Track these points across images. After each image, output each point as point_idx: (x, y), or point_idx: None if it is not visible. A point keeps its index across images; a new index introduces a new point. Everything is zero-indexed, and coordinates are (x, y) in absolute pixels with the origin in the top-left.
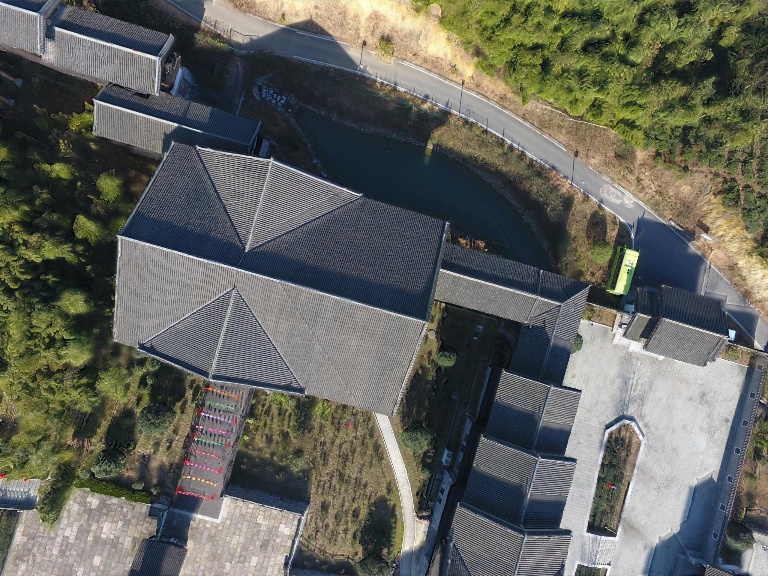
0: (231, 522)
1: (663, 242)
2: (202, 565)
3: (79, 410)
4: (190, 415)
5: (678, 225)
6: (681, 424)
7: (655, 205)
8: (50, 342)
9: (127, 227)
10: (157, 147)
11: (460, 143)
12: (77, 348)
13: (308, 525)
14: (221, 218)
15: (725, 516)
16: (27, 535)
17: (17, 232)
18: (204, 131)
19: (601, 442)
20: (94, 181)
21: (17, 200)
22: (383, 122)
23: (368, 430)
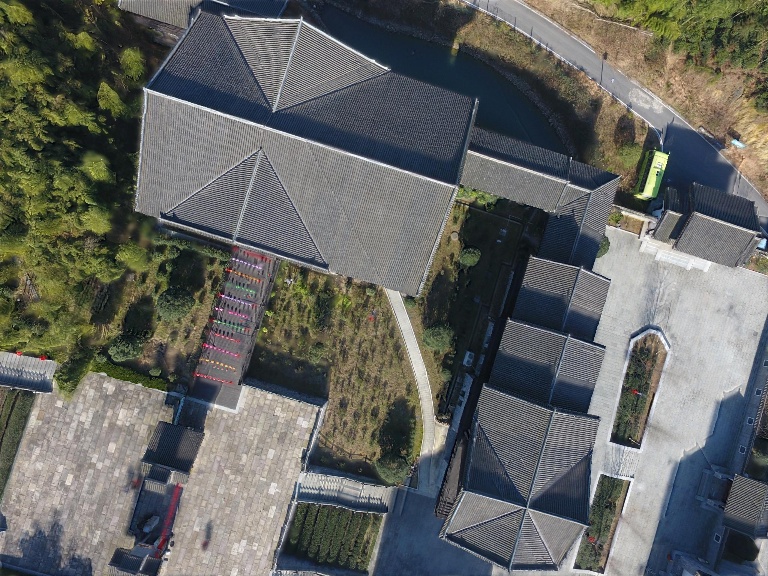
0: (248, 413)
1: (692, 149)
2: (218, 456)
3: (97, 295)
4: (209, 306)
5: (708, 132)
6: (708, 336)
7: (685, 111)
8: (72, 207)
9: (154, 83)
10: (183, 22)
11: (487, 41)
12: (99, 216)
13: (326, 422)
14: (248, 81)
15: (753, 428)
16: (42, 419)
17: (41, 94)
18: (231, 5)
19: (626, 351)
20: (118, 59)
21: (42, 62)
22: (409, 20)
23: (388, 330)
